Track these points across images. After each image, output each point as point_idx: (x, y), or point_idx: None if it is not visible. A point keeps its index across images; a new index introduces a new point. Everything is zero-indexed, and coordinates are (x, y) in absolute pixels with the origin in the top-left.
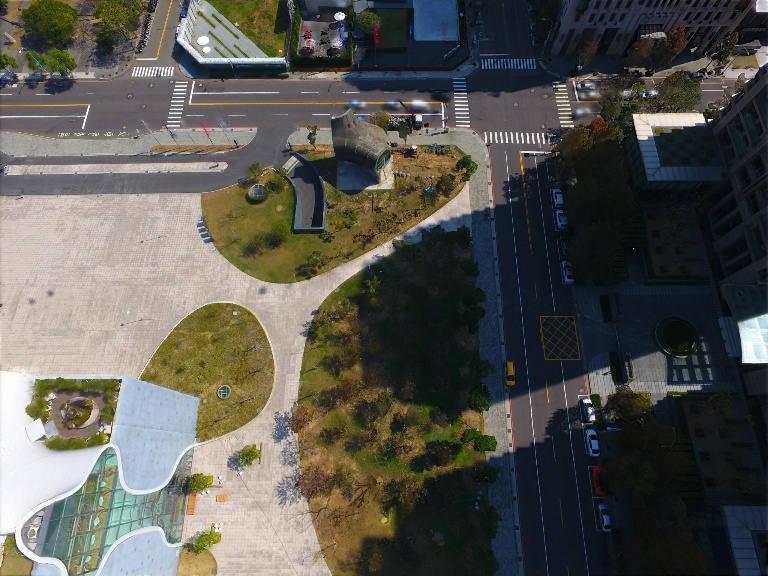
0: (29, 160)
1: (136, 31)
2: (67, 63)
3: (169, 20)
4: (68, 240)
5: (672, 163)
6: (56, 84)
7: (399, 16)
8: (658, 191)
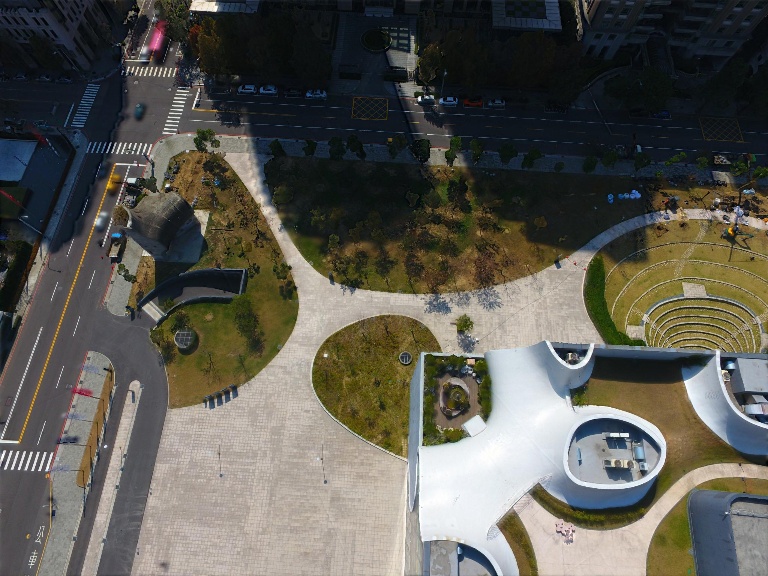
0: None
1: None
2: None
3: None
4: None
5: None
6: None
7: None
8: None
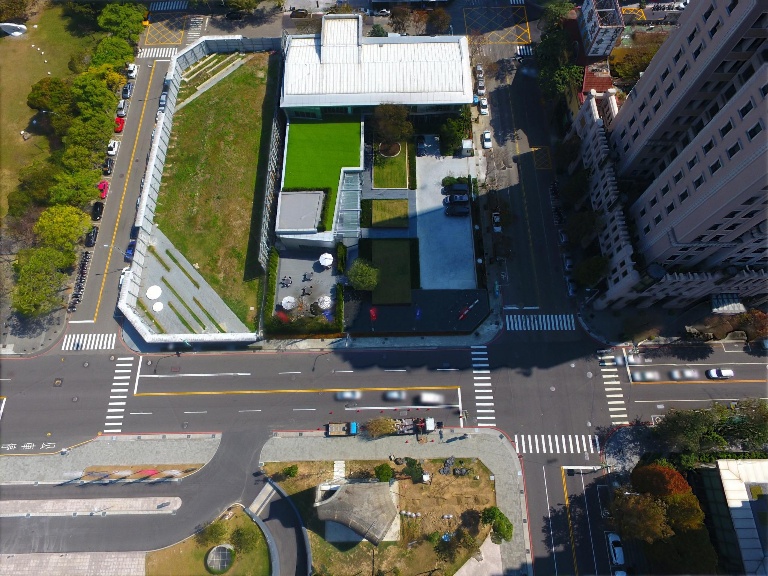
0: None
1: (70, 277)
2: None
3: (112, 259)
4: None
5: None
6: None
7: (401, 254)
8: None
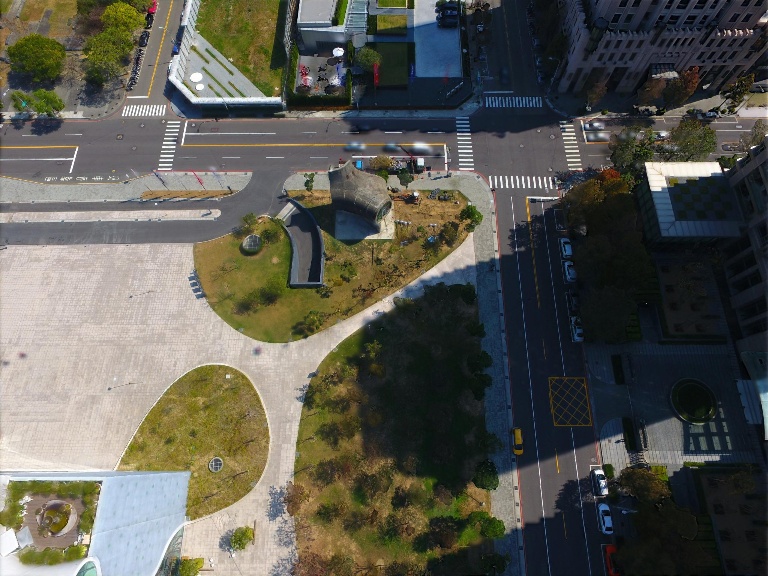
0: (14, 207)
1: (127, 67)
2: (54, 104)
3: (161, 55)
4: (54, 295)
5: (687, 217)
6: (43, 124)
7: (400, 51)
8: (672, 244)
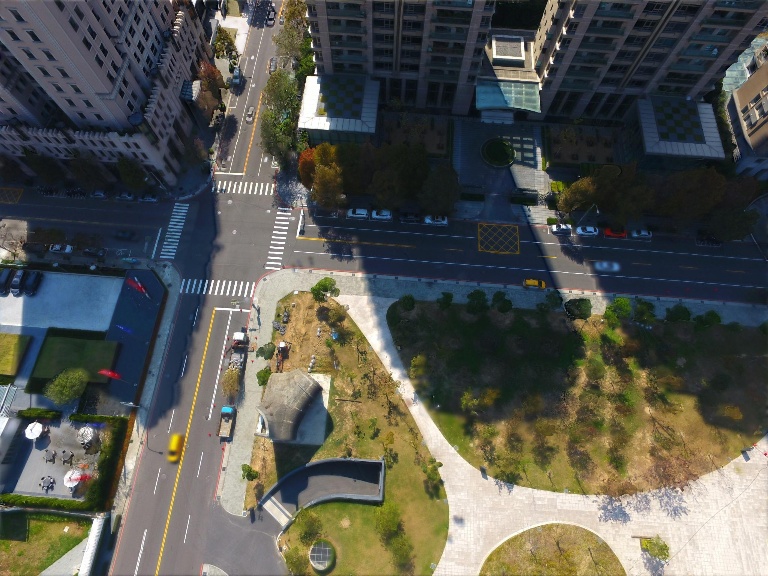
0: None
1: None
2: None
3: None
4: None
5: (358, 111)
6: None
7: (59, 347)
8: None
